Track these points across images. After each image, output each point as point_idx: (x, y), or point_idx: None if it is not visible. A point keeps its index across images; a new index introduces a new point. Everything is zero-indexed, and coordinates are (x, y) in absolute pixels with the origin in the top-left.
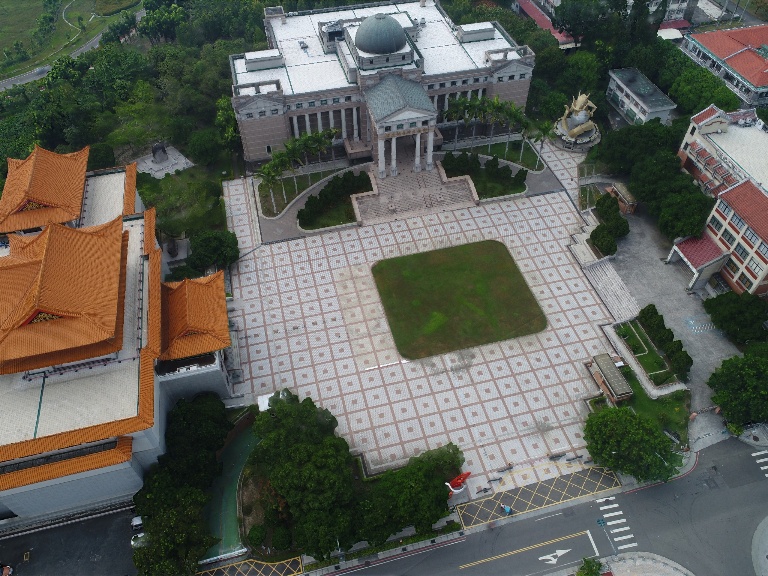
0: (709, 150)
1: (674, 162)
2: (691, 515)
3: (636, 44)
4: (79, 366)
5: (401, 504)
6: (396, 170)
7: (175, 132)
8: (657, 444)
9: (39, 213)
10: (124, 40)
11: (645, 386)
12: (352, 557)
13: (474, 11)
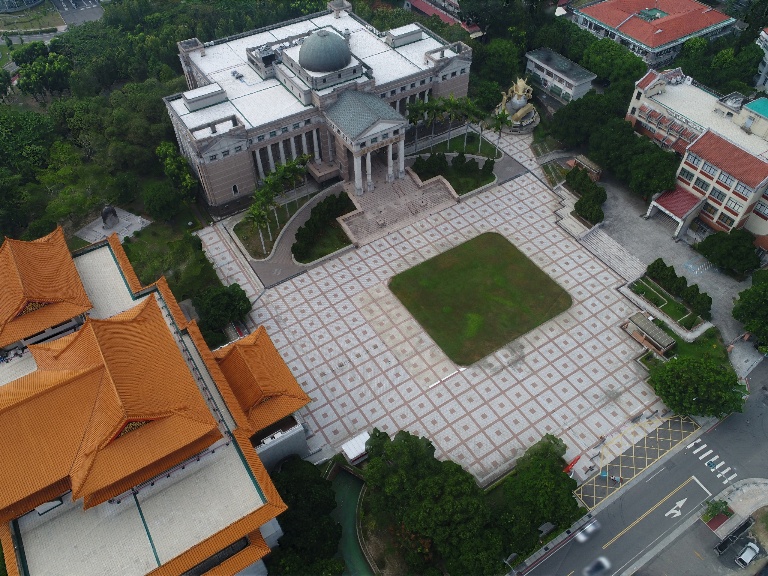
0: (659, 111)
1: (629, 127)
2: (766, 435)
3: (538, 25)
4: (169, 470)
5: (542, 506)
6: (372, 184)
7: (121, 191)
8: (728, 381)
9: (42, 313)
10: (1, 101)
11: (679, 333)
12: (503, 573)
13: (377, 15)
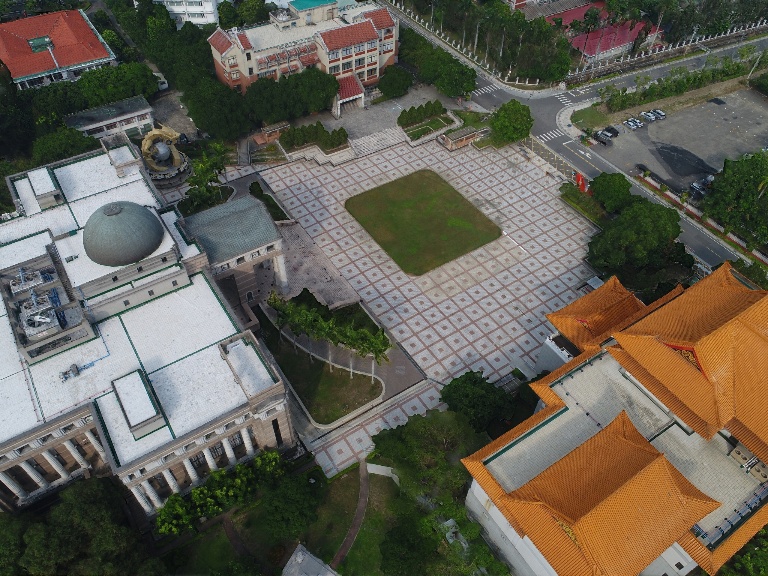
0: (272, 53)
1: (270, 79)
2: None
3: None
4: None
5: (629, 184)
6: None
7: None
8: None
9: None
10: None
11: (456, 127)
12: None
13: None
